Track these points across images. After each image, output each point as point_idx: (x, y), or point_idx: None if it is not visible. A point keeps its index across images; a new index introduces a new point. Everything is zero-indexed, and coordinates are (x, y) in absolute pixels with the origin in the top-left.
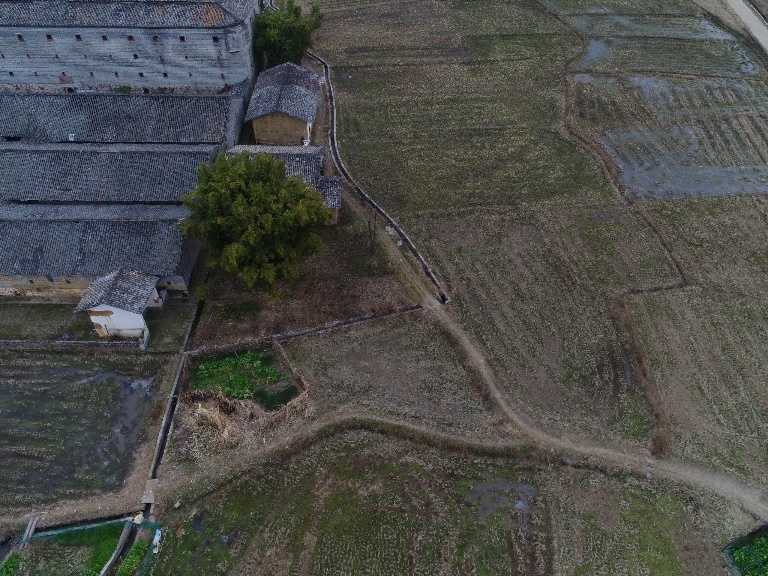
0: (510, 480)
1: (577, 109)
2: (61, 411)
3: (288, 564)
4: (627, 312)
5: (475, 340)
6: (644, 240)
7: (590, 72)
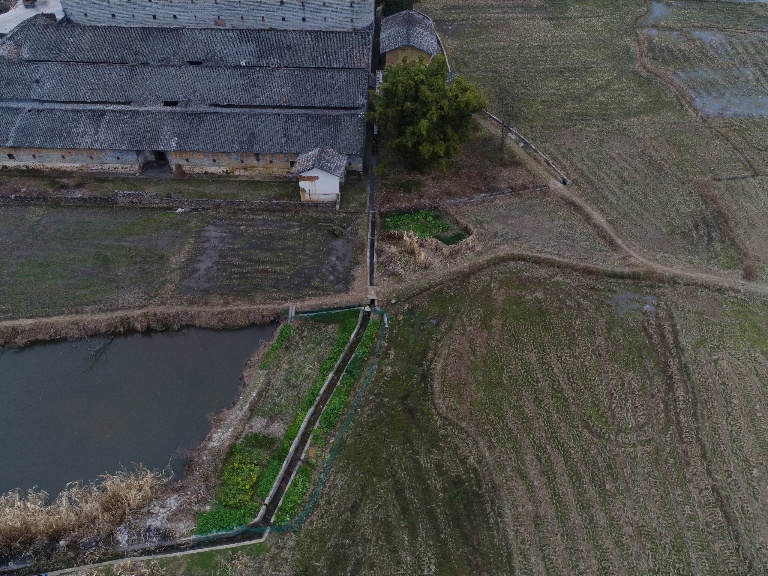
0: (637, 293)
1: (649, 54)
2: (287, 246)
3: (484, 335)
4: (712, 192)
5: (595, 207)
6: (719, 146)
7: (656, 27)
